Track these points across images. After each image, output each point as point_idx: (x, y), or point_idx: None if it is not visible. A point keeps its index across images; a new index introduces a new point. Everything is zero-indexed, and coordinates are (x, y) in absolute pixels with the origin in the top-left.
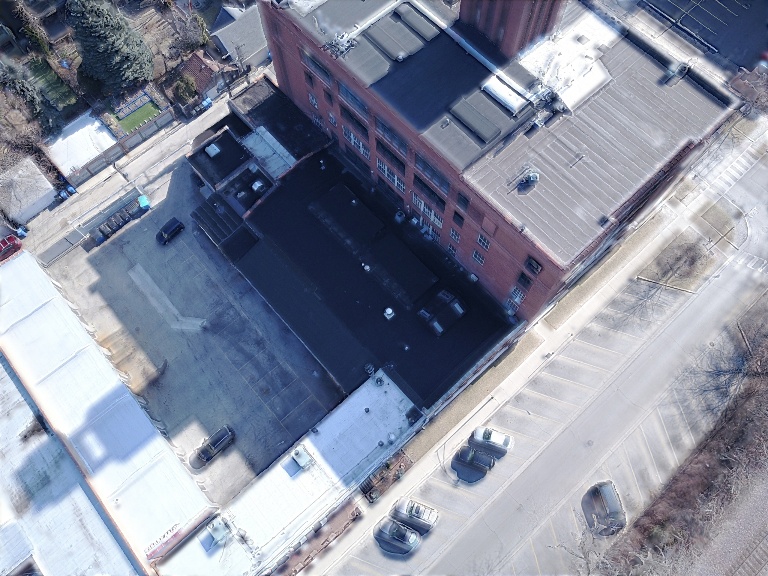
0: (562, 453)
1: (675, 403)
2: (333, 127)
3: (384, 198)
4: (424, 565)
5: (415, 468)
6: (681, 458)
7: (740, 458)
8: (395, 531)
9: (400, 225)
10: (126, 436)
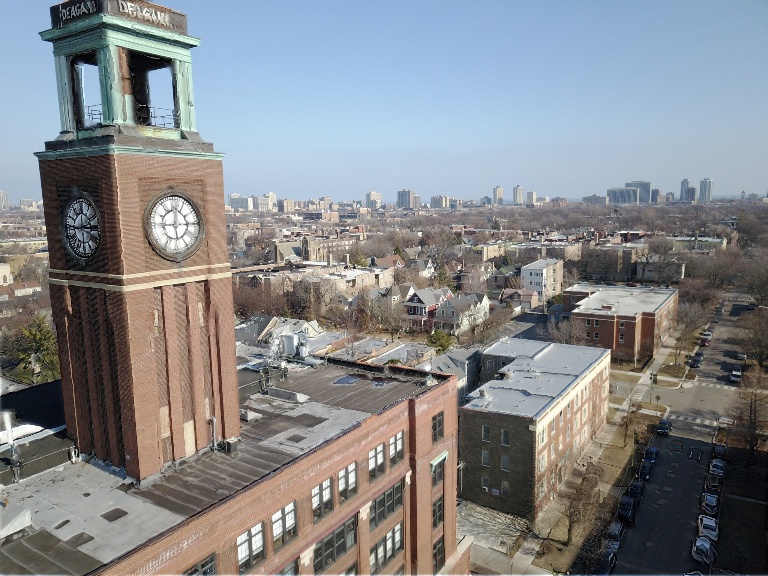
0: None
1: None
2: None
3: None
4: None
5: None
6: None
7: None
8: None
9: None
10: None
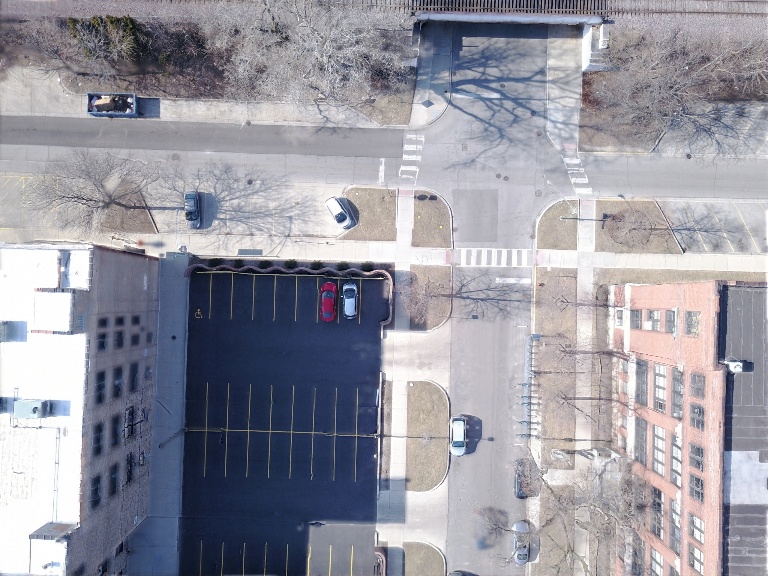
0: None
1: (767, 145)
2: None
3: None
4: None
5: None
6: None
7: None
8: None
9: None
10: None
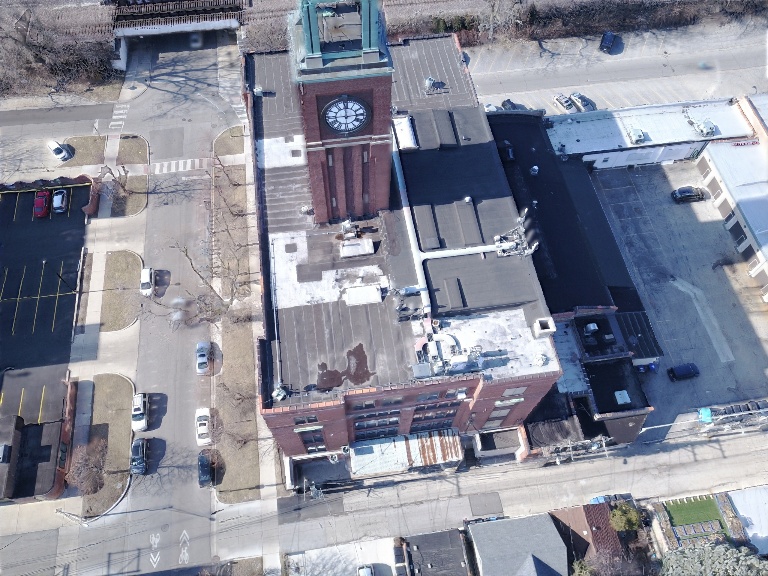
0: None
1: None
2: None
3: None
4: (575, 87)
5: None
6: None
7: None
8: (585, 102)
9: None
10: (763, 207)
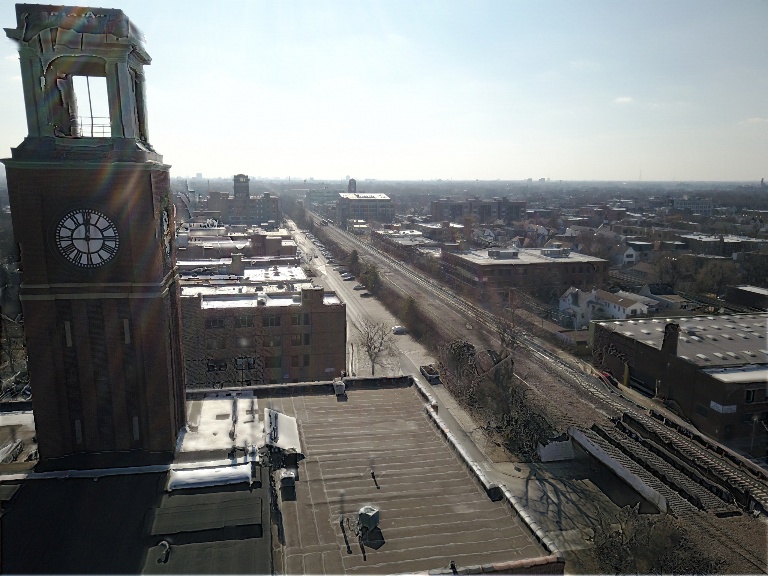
0: None
1: None
2: None
3: None
4: None
5: None
6: None
7: None
8: None
9: None
10: None
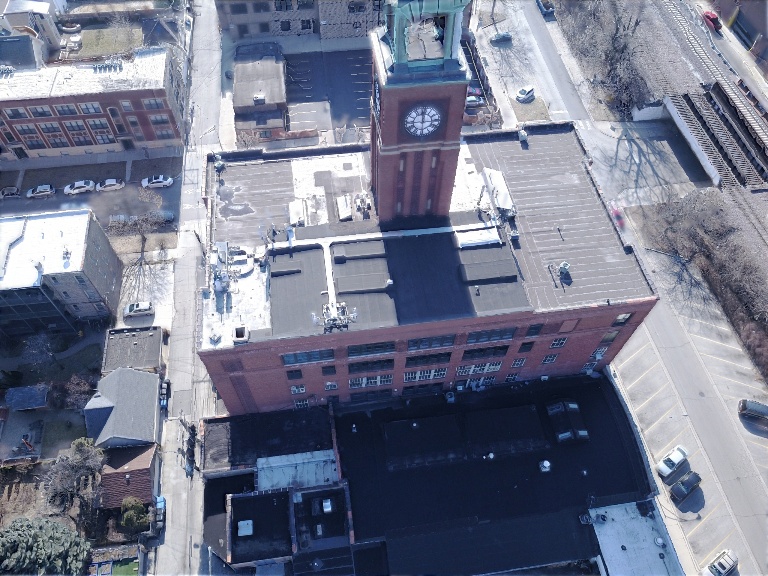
0: (703, 419)
1: (691, 321)
2: (332, 392)
3: (418, 399)
4: None
5: (674, 545)
6: (736, 345)
7: (759, 309)
8: None
9: (456, 403)
10: None
